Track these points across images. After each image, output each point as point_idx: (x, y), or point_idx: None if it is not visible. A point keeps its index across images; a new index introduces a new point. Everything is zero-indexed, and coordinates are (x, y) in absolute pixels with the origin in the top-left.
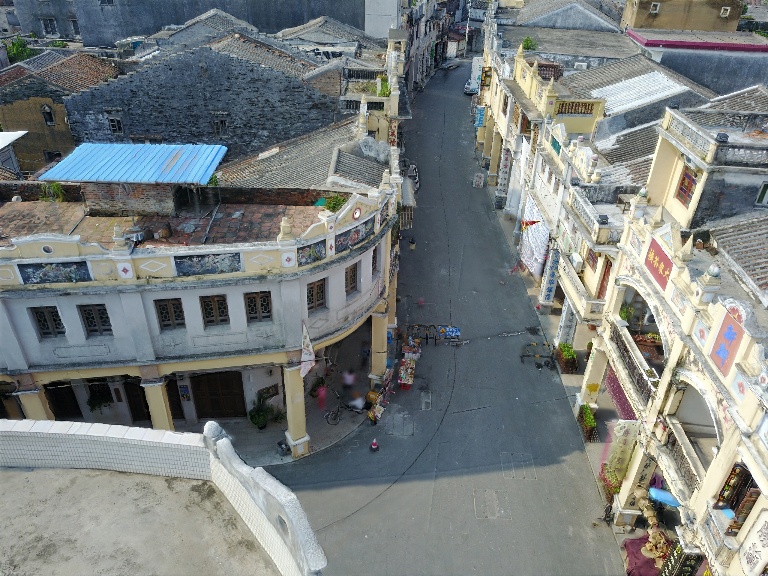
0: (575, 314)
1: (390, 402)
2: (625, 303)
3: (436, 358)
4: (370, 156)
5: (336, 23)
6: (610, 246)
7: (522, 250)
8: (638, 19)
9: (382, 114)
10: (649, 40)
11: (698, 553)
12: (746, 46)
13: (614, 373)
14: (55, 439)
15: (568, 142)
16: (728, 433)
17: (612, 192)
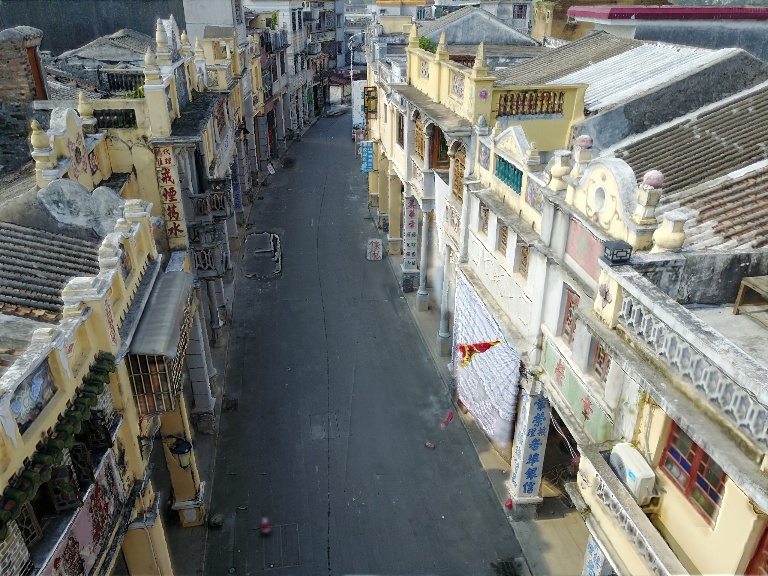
0: None
1: None
2: None
3: None
4: (76, 226)
5: (144, 38)
6: None
7: (460, 381)
8: (554, 32)
9: (135, 135)
10: (614, 8)
11: None
12: (759, 10)
13: None
14: None
15: (538, 161)
16: None
17: (719, 273)
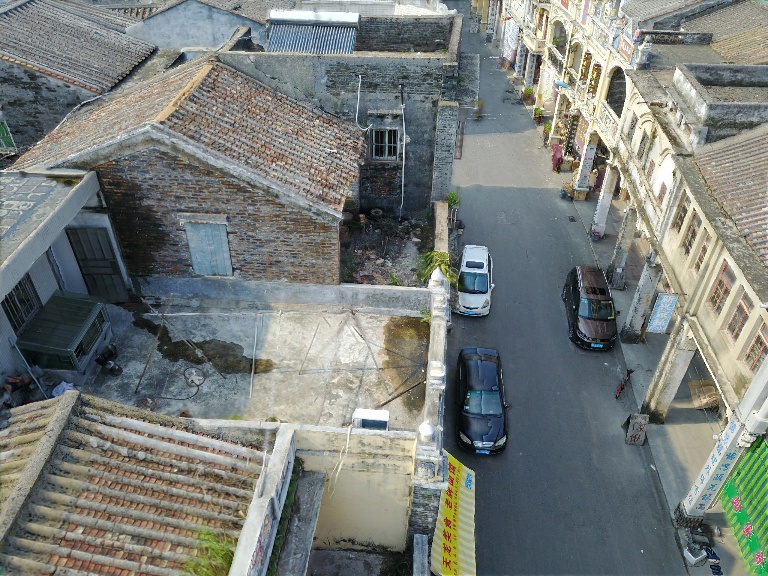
0: (530, 51)
1: None
2: (555, 37)
3: None
4: None
5: None
6: (546, 3)
7: (504, 50)
8: None
9: None
10: None
11: (578, 115)
12: None
13: None
14: (342, 5)
15: None
16: (584, 45)
17: None
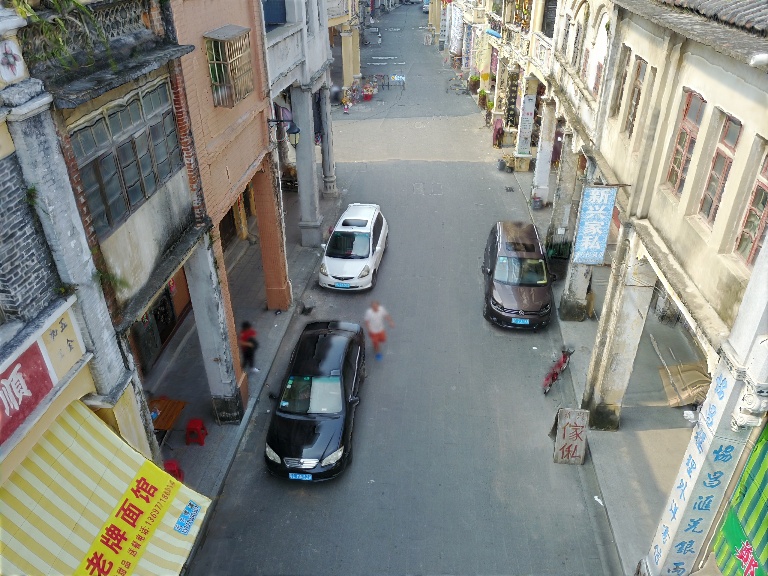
0: (469, 24)
1: (357, 104)
2: (495, 4)
3: (389, 93)
4: None
5: None
6: None
7: (451, 45)
8: None
9: None
10: None
11: (517, 73)
12: None
13: (494, 55)
14: None
15: None
16: None
17: None
